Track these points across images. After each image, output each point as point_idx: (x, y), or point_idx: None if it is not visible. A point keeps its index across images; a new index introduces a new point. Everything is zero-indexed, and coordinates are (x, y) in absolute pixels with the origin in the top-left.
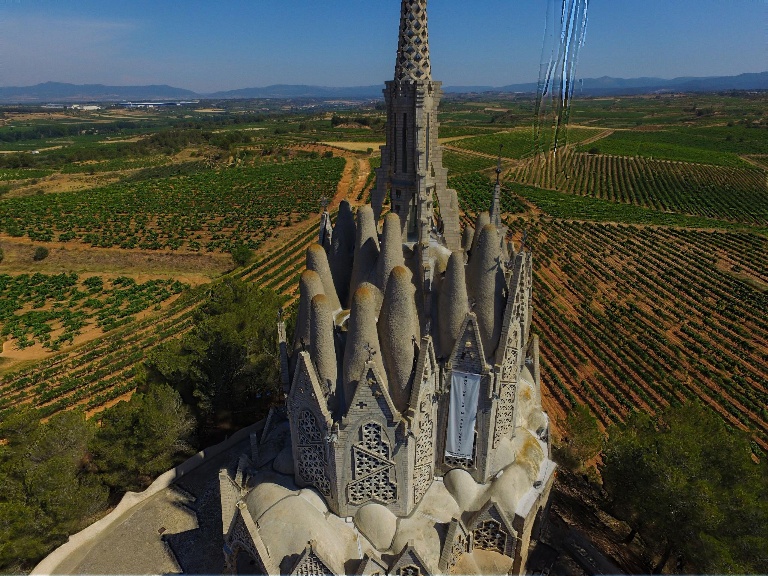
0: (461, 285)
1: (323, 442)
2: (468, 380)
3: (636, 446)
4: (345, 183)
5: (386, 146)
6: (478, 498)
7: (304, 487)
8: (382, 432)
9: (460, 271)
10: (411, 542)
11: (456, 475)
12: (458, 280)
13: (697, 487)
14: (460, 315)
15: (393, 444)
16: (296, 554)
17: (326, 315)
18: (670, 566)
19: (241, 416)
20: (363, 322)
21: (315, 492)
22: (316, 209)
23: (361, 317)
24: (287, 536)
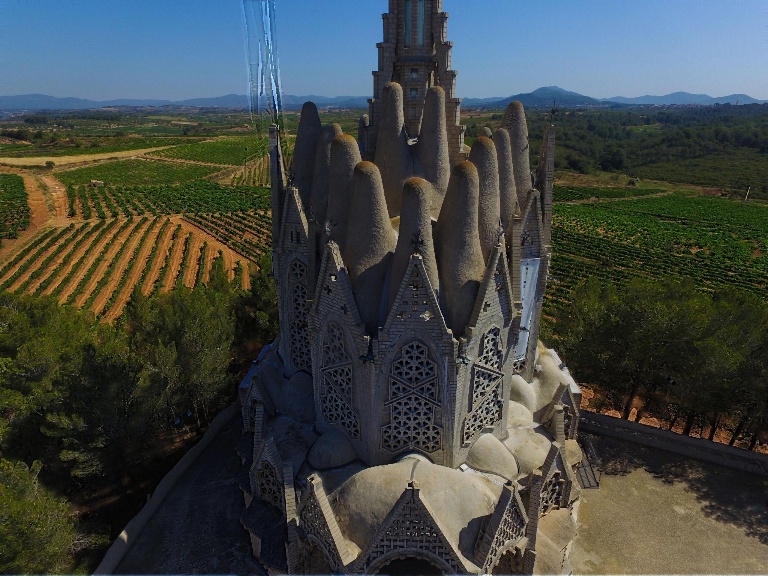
0: (511, 165)
1: (438, 376)
2: (529, 267)
3: (618, 303)
4: (37, 201)
5: (393, 14)
6: (539, 395)
7: (390, 462)
8: (498, 337)
9: (510, 149)
10: (557, 444)
11: (515, 381)
12: (509, 159)
13: (686, 307)
14: (514, 198)
15: (504, 350)
16: (473, 519)
17: (428, 203)
18: (642, 398)
19: (151, 463)
20: (475, 202)
21: (419, 454)
22: (11, 233)
23: (473, 195)
24: (453, 505)
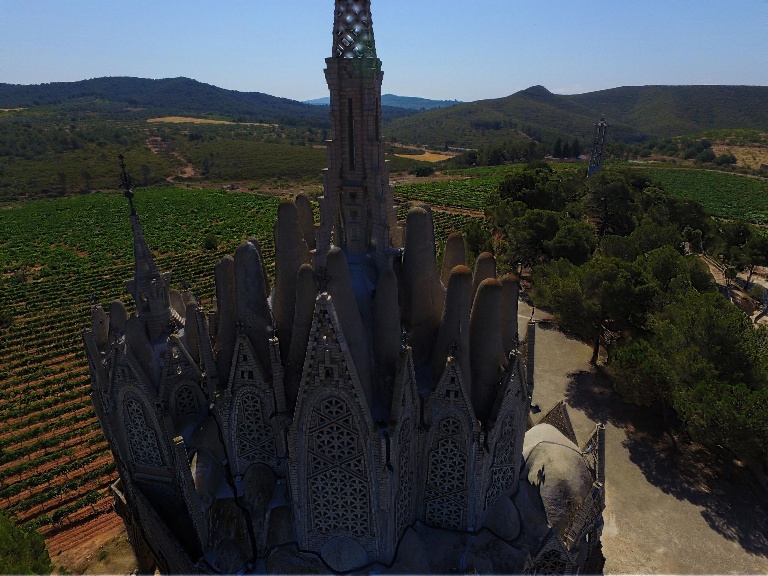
0: None
1: None
2: None
3: None
4: None
5: None
6: None
7: None
8: None
9: None
10: None
11: None
12: None
13: None
14: None
15: None
16: None
17: None
18: None
19: None
20: None
21: None
22: None
23: None
24: None
